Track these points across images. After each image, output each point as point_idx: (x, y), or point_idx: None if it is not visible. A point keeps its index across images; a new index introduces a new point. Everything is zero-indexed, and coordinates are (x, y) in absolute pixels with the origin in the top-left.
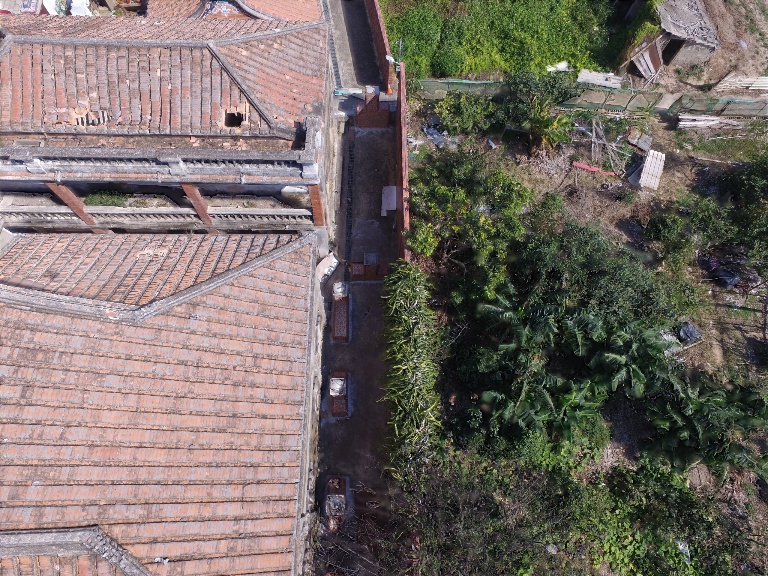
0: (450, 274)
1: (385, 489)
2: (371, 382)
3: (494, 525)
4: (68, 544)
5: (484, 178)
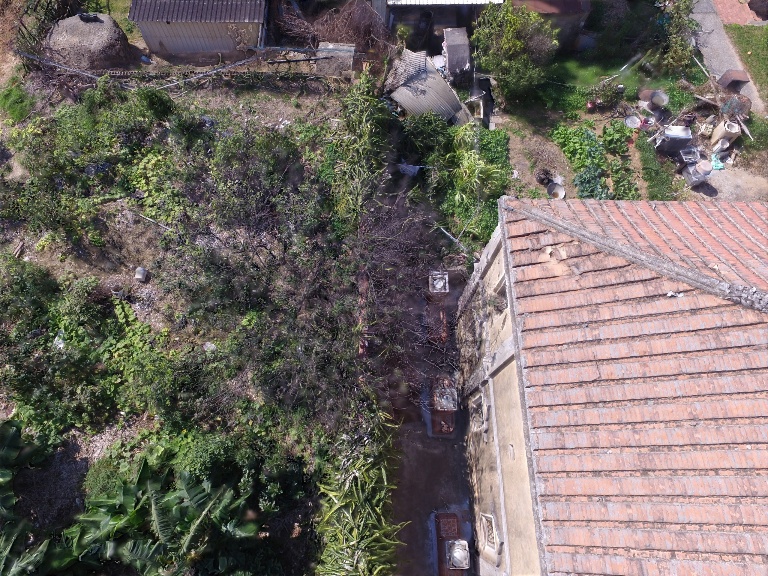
0: None
1: None
2: (405, 567)
3: (270, 369)
4: None
5: None
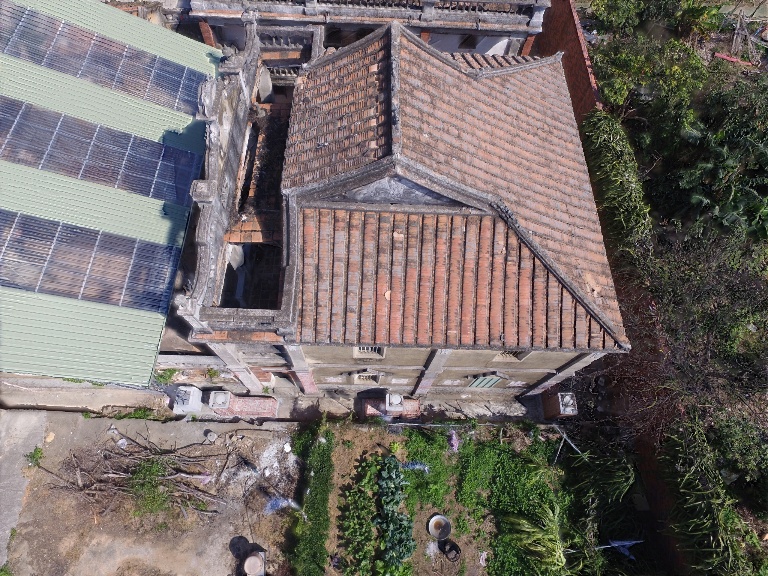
0: (626, 131)
1: None
2: None
3: (703, 307)
4: (482, 202)
5: (660, 47)
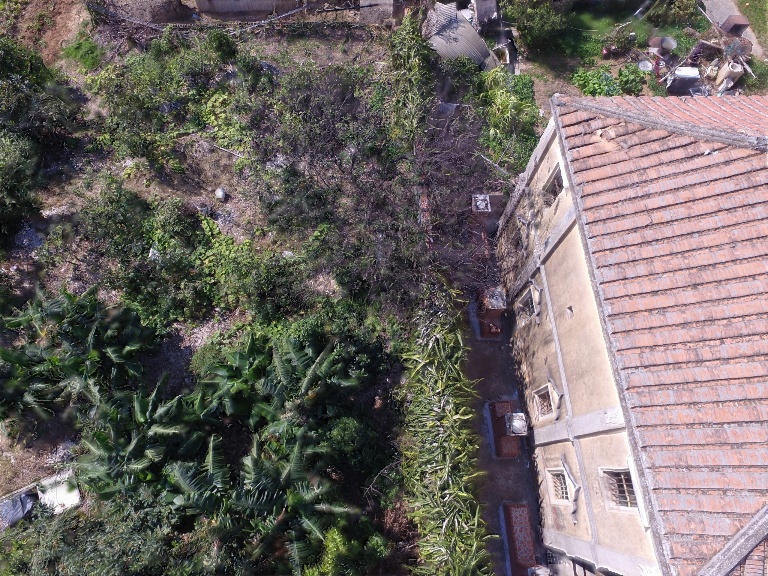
0: None
1: None
2: None
3: None
4: None
5: None
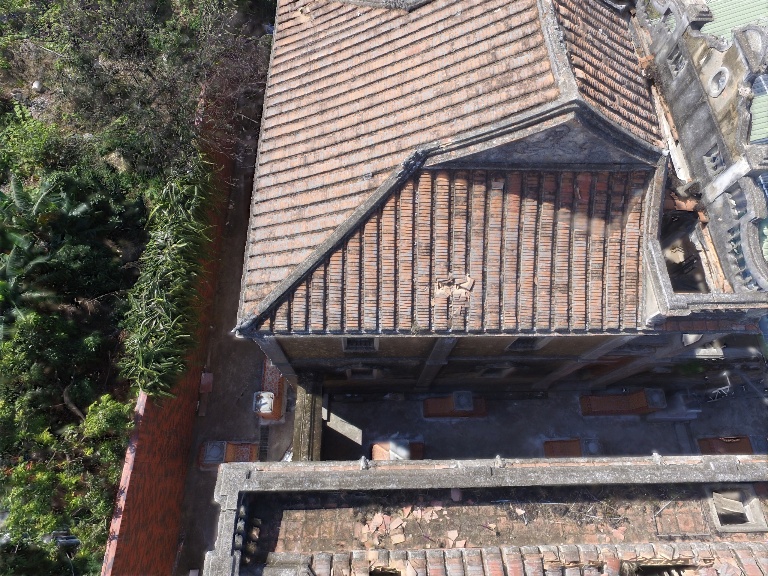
0: None
1: (243, 219)
2: None
3: None
4: None
5: None
